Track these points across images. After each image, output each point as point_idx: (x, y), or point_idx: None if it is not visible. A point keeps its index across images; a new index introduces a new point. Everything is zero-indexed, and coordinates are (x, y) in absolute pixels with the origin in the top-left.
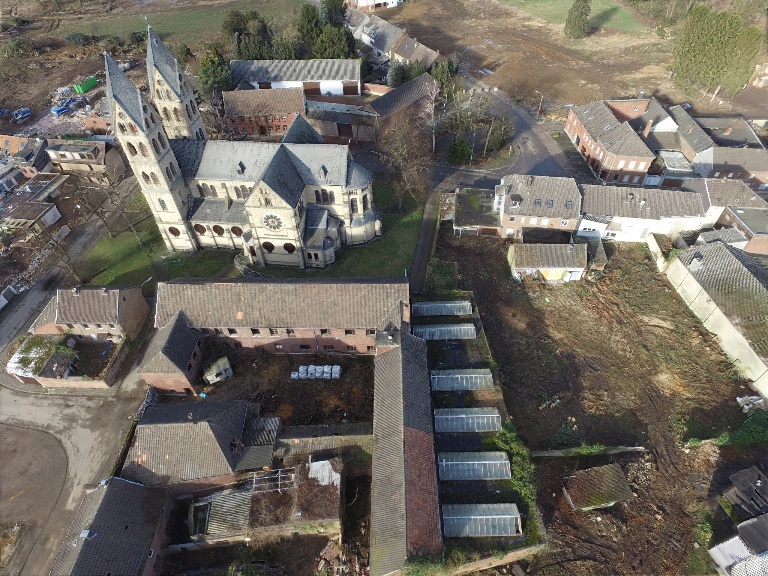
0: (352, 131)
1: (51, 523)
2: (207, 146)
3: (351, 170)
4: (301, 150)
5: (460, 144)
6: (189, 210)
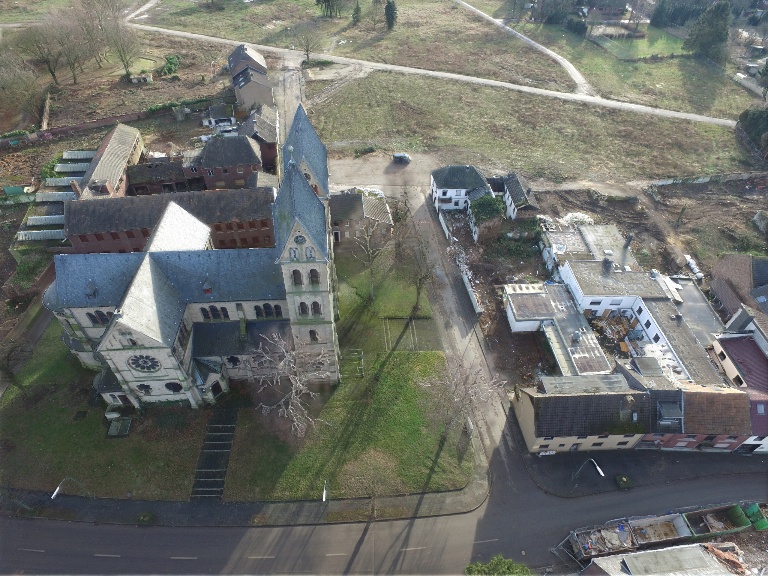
0: None
1: None
2: None
3: None
4: None
5: None
6: None
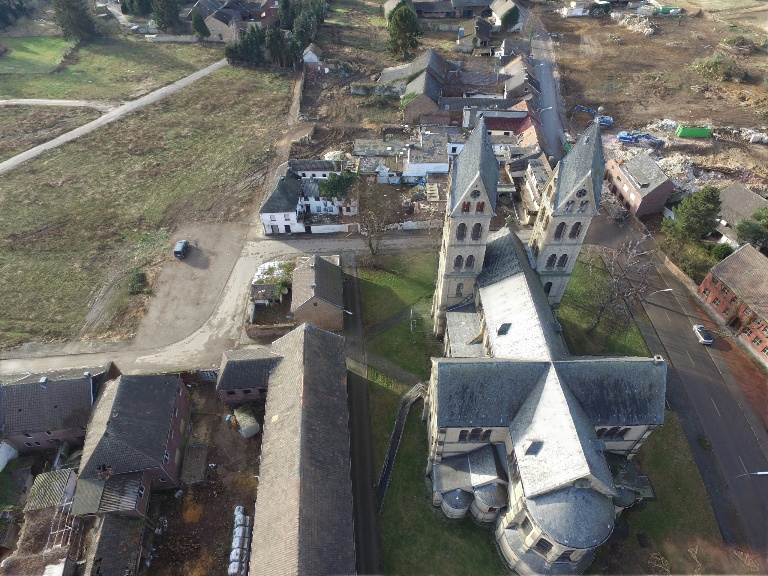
0: None
1: (129, 354)
2: (516, 276)
3: (562, 497)
4: (553, 395)
5: None
6: (459, 305)
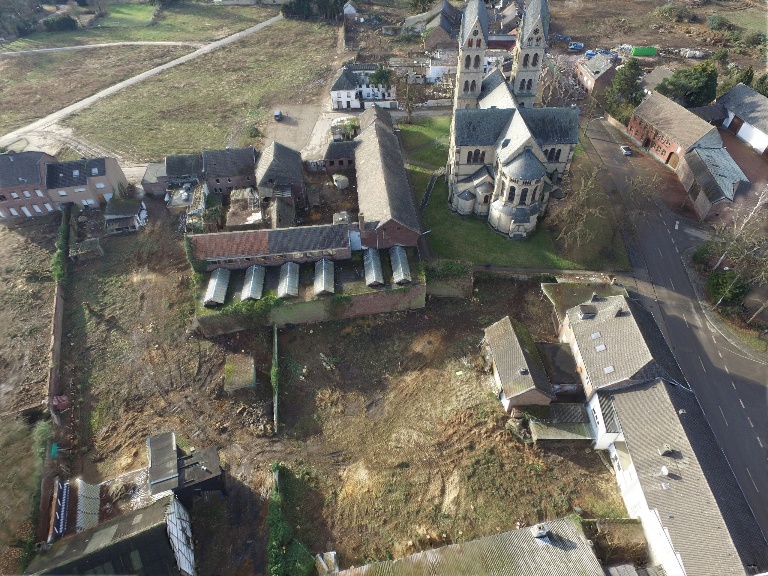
0: (698, 195)
1: None
2: (500, 85)
3: (519, 158)
4: (516, 120)
5: (726, 276)
6: None
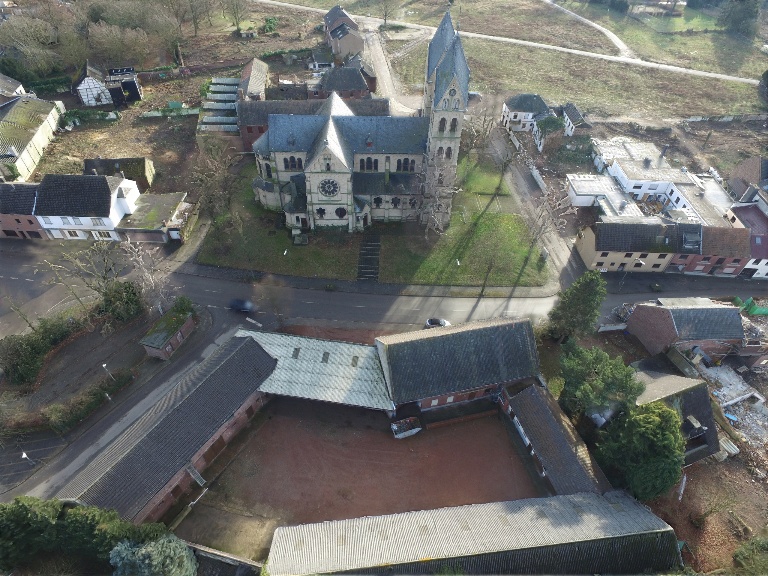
0: None
1: None
2: None
3: None
4: None
5: (123, 283)
6: None
